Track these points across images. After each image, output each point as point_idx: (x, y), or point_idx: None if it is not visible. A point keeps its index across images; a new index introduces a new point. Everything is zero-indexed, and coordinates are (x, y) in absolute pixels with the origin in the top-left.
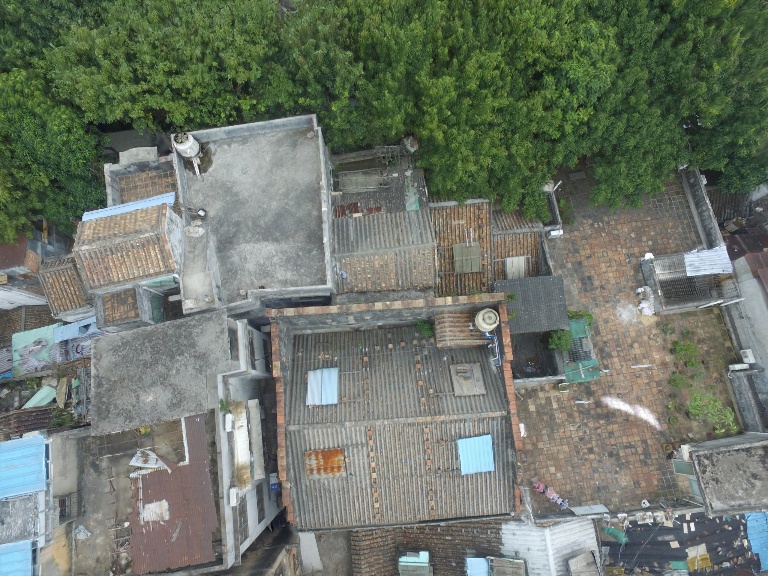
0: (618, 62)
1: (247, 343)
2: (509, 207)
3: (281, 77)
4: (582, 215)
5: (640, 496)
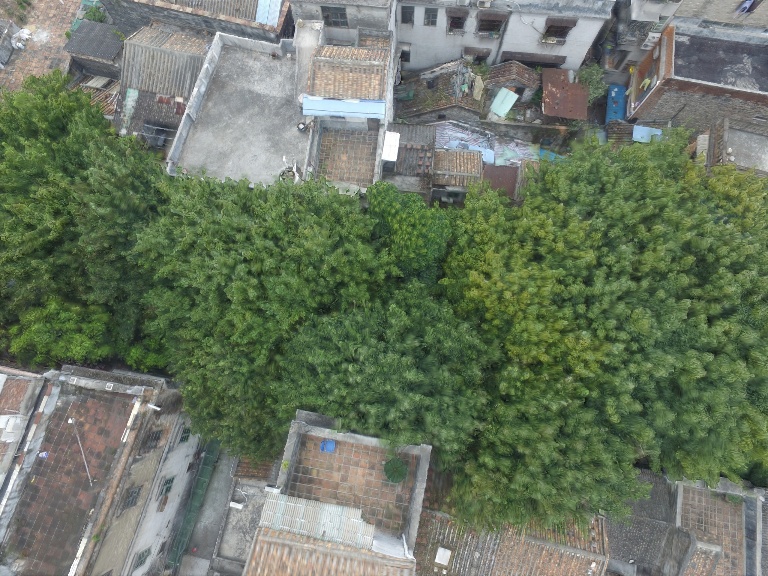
0: None
1: None
2: None
3: None
4: None
5: None
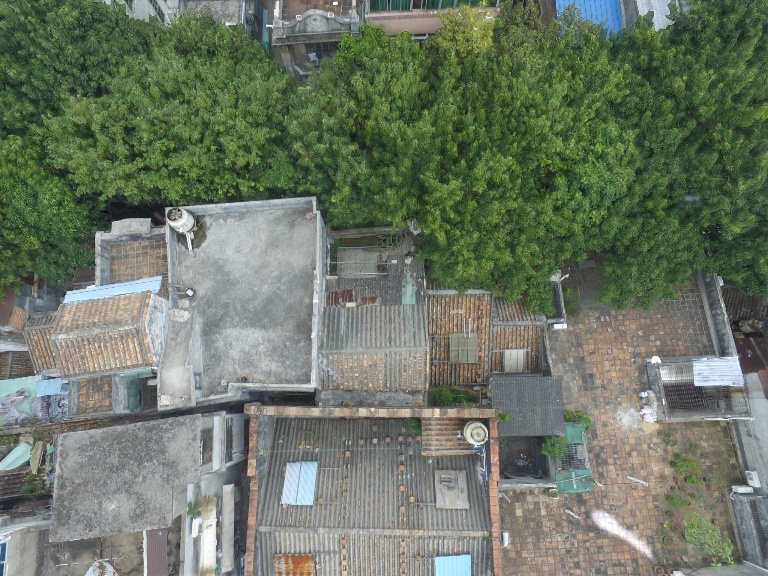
0: (637, 166)
1: (223, 438)
2: (512, 297)
3: (282, 161)
4: (589, 307)
5: None
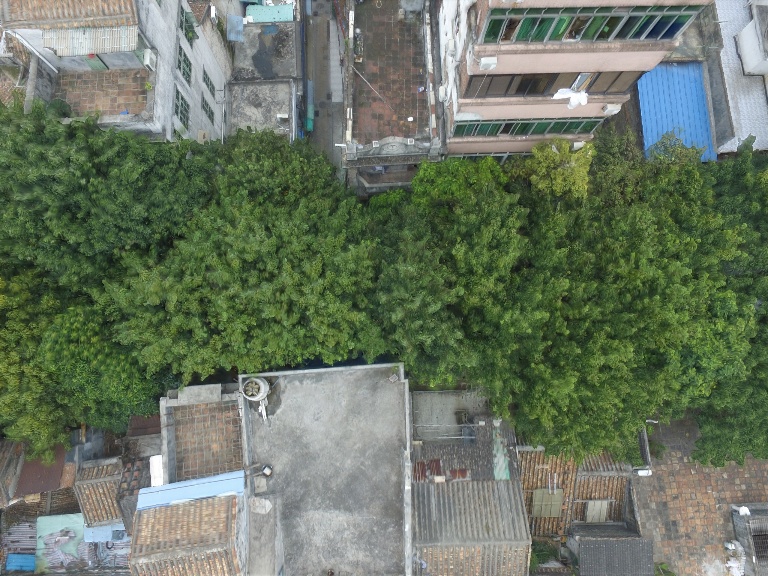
0: (752, 336)
1: None
2: None
3: (373, 336)
4: (671, 446)
5: None
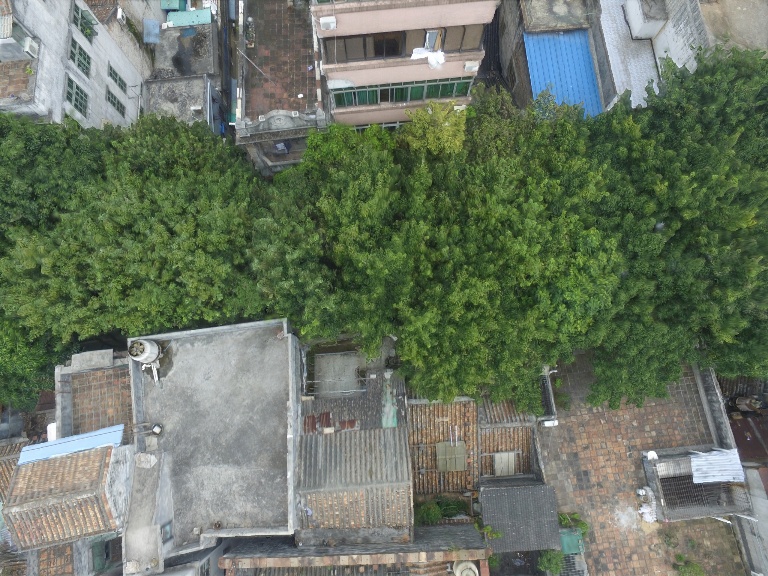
0: (621, 272)
1: None
2: (499, 398)
3: (247, 290)
4: (580, 397)
5: None
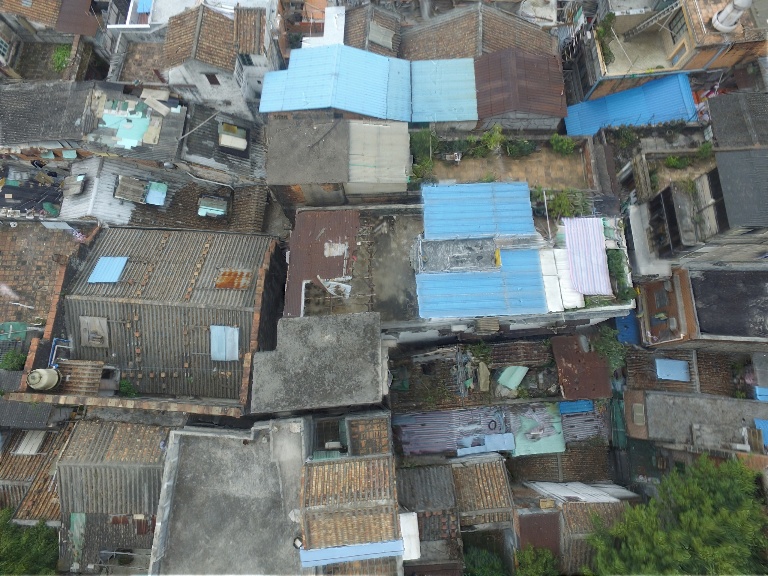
0: None
1: None
2: (4, 513)
3: None
4: None
5: (15, 230)
